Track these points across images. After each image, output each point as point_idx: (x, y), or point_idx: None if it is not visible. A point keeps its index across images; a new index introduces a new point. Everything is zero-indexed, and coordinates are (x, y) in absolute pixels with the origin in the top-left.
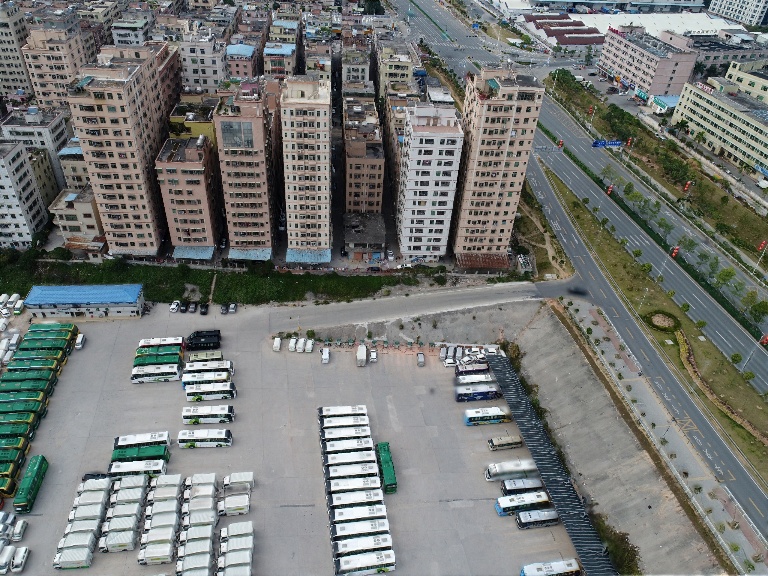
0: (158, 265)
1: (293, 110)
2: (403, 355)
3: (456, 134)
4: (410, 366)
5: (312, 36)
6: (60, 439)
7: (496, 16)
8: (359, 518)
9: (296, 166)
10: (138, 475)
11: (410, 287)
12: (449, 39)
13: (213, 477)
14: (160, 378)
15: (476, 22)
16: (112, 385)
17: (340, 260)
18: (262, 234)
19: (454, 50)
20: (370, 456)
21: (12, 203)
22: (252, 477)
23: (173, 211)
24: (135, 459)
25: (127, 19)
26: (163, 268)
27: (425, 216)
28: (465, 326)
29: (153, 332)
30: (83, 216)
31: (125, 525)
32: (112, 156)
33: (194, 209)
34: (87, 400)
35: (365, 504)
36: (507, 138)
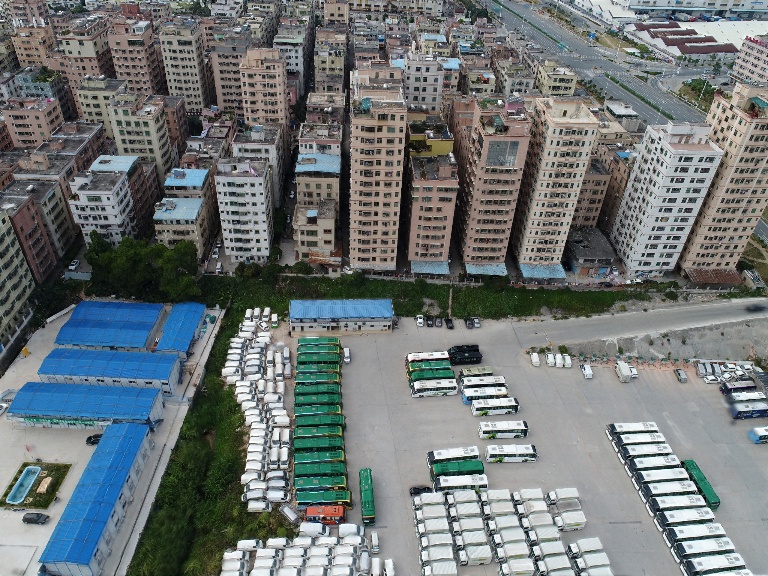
0: (395, 280)
1: (563, 129)
2: (660, 371)
3: (716, 152)
4: (672, 382)
5: (467, 50)
6: (370, 452)
7: (600, 25)
8: (701, 536)
9: (550, 184)
10: (467, 489)
11: (643, 302)
12: (566, 49)
13: (541, 493)
14: (440, 392)
15: (584, 31)
16: (394, 399)
17: (566, 275)
18: (499, 249)
19: (582, 60)
20: (683, 474)
21: (259, 219)
22: (578, 493)
23: (418, 227)
24: (456, 473)
25: (283, 35)
26: (400, 282)
27: (664, 232)
28: (714, 342)
29: (410, 346)
30: (323, 232)
31: (479, 539)
32: (378, 175)
33: (439, 225)
34: (377, 414)
35: (696, 522)
36: (766, 156)
